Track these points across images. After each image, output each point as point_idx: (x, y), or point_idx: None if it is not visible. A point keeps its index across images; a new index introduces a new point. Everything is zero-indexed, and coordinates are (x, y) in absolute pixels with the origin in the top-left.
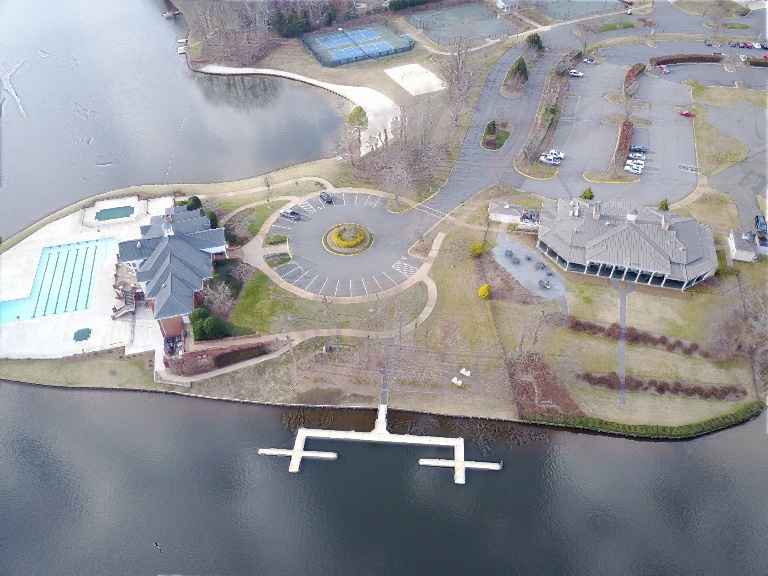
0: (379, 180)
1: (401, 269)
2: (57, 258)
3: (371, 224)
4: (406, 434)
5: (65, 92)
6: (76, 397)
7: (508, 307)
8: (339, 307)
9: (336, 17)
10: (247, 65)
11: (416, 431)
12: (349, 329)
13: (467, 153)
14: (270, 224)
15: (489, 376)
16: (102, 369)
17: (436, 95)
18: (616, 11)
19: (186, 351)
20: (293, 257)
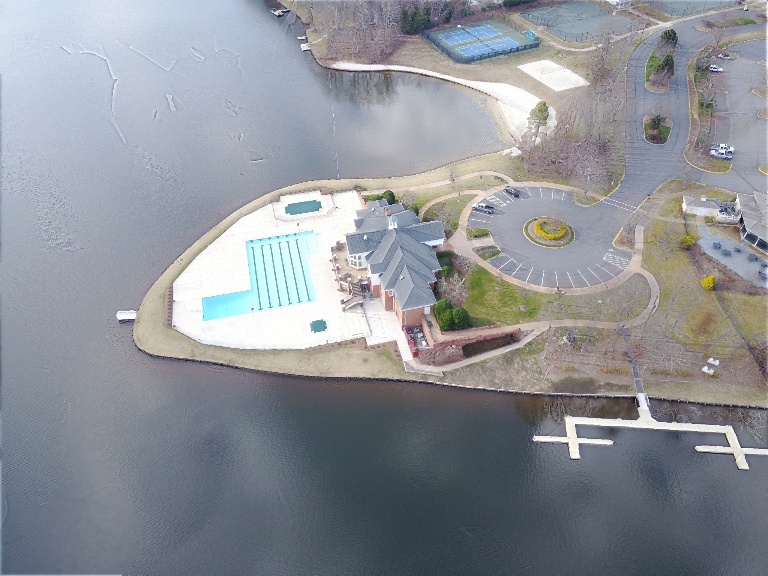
0: (554, 174)
1: (613, 261)
2: (262, 251)
3: (566, 217)
4: (673, 422)
5: (219, 89)
6: (331, 387)
7: (735, 298)
8: (567, 298)
9: (452, 14)
10: (377, 62)
11: (680, 419)
12: (583, 320)
13: (634, 147)
14: (466, 217)
15: (738, 365)
16: (350, 359)
17: (579, 91)
18: (731, 7)
19: (436, 341)
20: (502, 250)
